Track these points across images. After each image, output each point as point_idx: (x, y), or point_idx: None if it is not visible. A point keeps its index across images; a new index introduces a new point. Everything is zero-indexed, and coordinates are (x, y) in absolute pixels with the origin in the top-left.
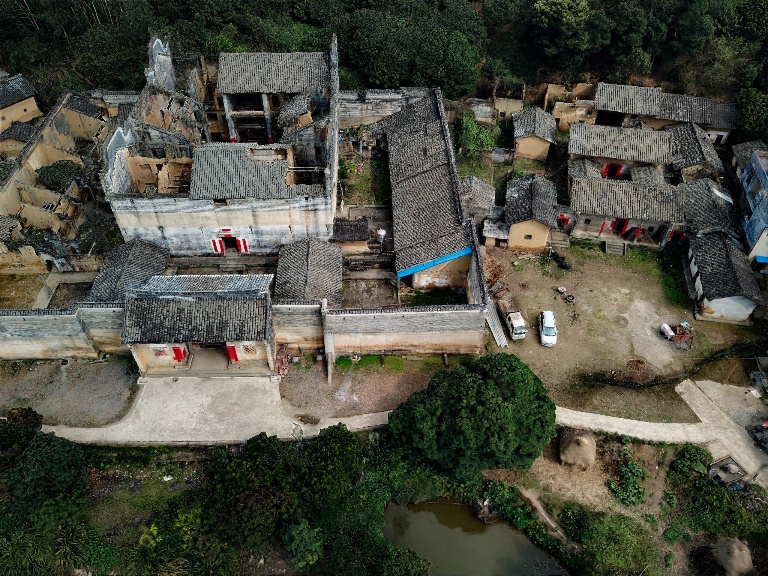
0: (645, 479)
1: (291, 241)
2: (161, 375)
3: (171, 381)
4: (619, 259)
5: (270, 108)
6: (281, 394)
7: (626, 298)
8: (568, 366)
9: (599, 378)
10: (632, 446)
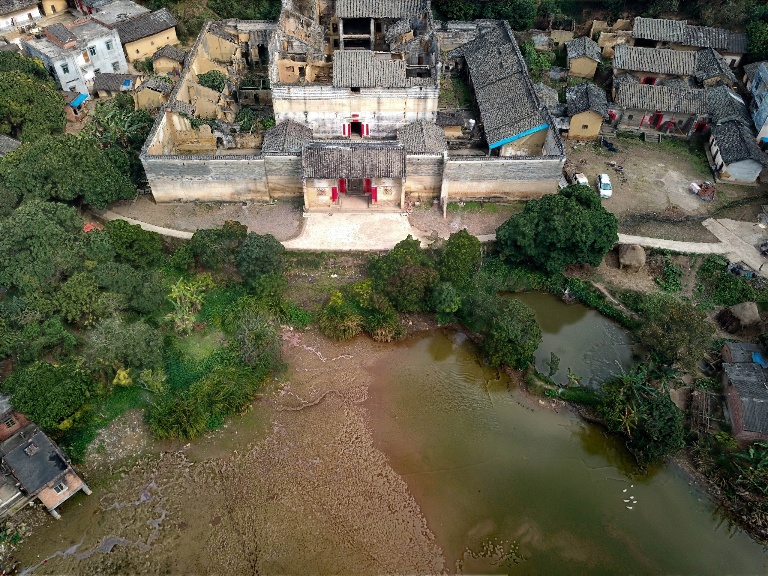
0: (681, 275)
1: (403, 126)
2: (319, 212)
3: (328, 215)
4: (655, 145)
5: (374, 33)
6: (410, 224)
7: (662, 169)
8: (621, 210)
9: (645, 217)
10: (671, 256)
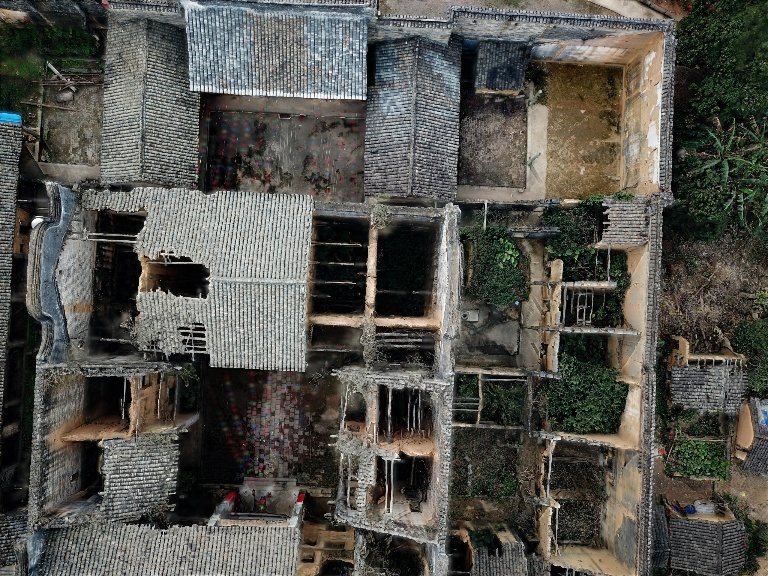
0: None
1: None
2: None
3: None
4: None
5: None
6: None
7: None
8: None
9: None
10: None
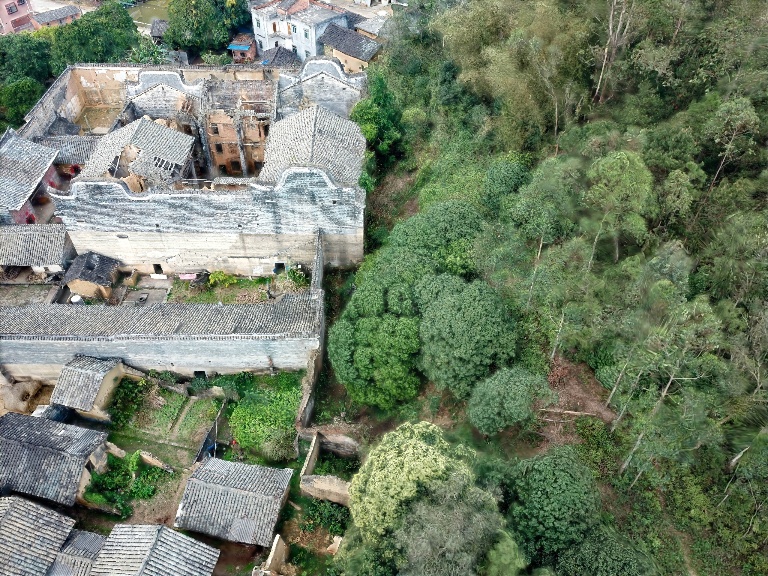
0: None
1: None
2: None
3: None
4: None
5: None
6: None
7: None
8: None
9: None
10: None
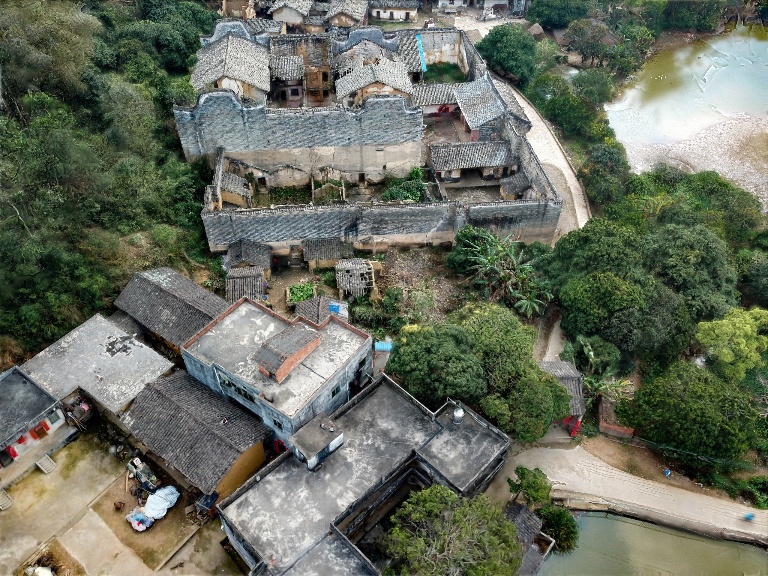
0: None
1: None
2: None
3: None
4: None
5: None
6: None
7: None
8: None
9: None
10: None
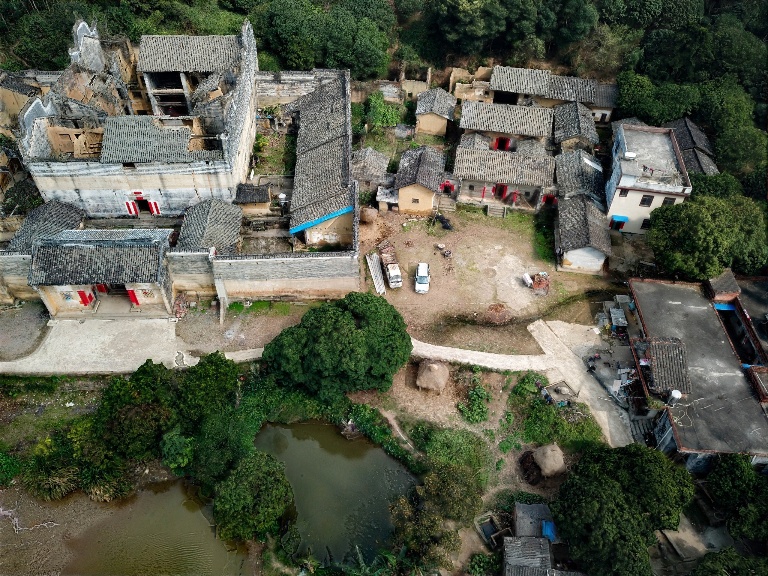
0: (489, 401)
1: (198, 203)
2: (69, 318)
3: (78, 323)
4: (499, 221)
5: (190, 87)
6: (176, 333)
7: (498, 253)
8: (436, 309)
9: (462, 319)
10: (482, 374)
